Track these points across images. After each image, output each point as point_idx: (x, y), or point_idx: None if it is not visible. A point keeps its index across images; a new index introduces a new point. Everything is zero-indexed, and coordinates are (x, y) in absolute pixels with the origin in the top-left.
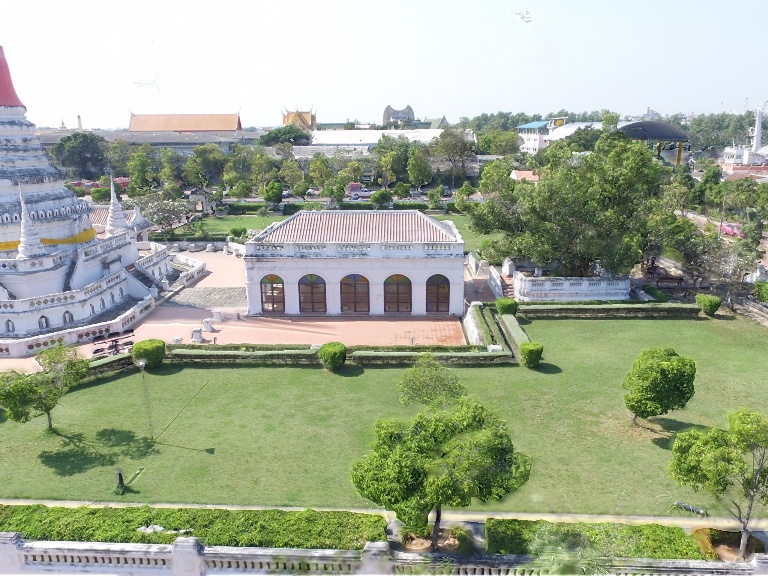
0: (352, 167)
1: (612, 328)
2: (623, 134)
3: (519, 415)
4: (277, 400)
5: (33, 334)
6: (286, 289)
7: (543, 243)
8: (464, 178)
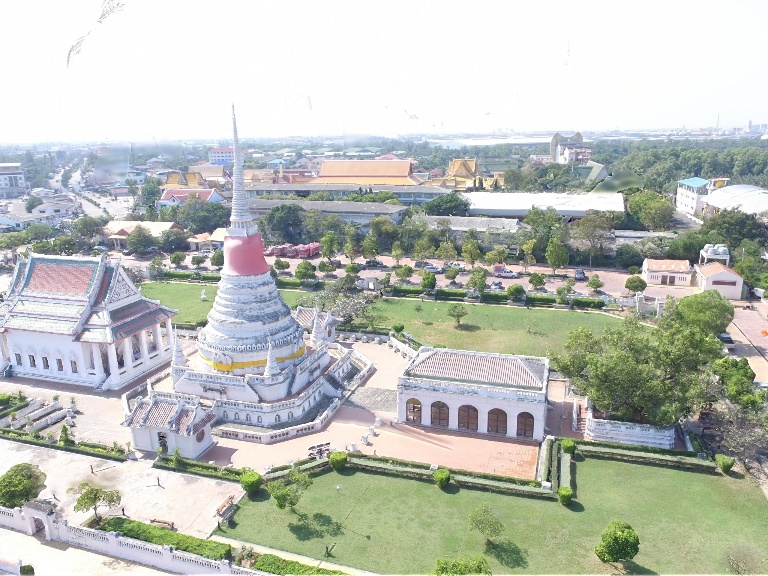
0: (498, 251)
1: (641, 475)
2: (681, 315)
3: (541, 542)
4: (406, 506)
5: (272, 426)
6: (423, 409)
7: (605, 398)
8: (601, 258)
